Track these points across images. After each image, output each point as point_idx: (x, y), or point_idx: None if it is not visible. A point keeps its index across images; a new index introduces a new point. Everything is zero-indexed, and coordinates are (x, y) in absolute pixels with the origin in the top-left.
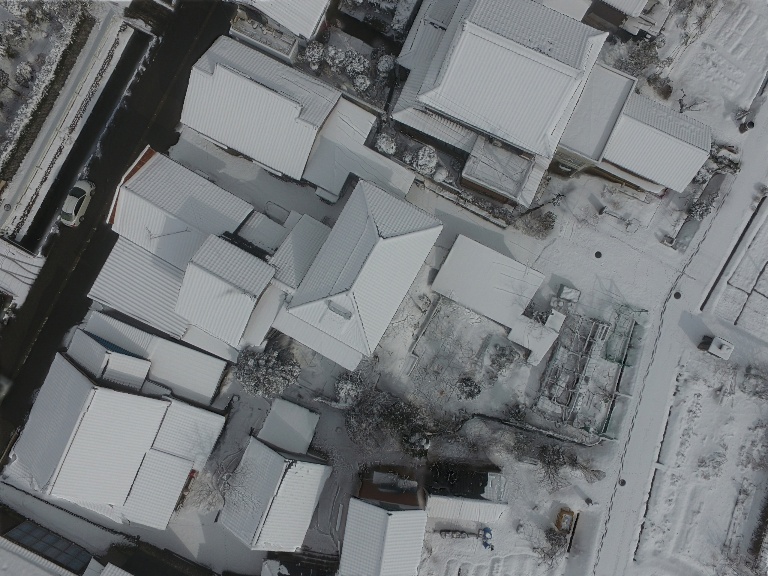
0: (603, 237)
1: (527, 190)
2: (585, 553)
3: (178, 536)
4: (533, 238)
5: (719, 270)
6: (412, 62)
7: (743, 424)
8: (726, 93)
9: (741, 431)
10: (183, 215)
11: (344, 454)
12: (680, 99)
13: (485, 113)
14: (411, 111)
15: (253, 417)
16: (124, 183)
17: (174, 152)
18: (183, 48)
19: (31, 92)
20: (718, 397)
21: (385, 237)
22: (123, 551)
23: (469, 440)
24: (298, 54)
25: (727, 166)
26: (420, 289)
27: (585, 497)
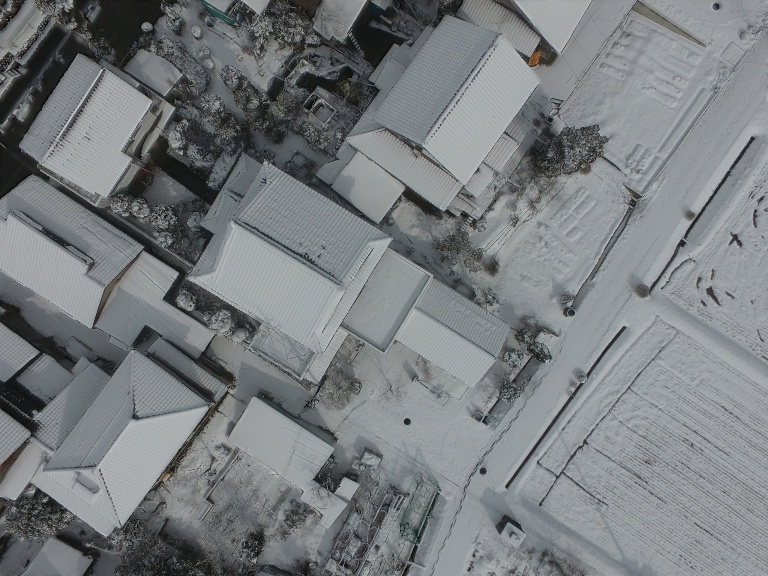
0: (414, 404)
1: (317, 367)
2: None
3: None
4: (330, 407)
5: (528, 450)
6: (215, 227)
7: None
8: (555, 275)
9: None
10: None
11: None
12: None
13: (258, 303)
14: None
15: (31, 550)
16: None
17: None
18: (8, 171)
19: None
20: None
21: (140, 417)
22: None
23: None
24: (111, 199)
25: (535, 357)
26: (217, 439)
27: None
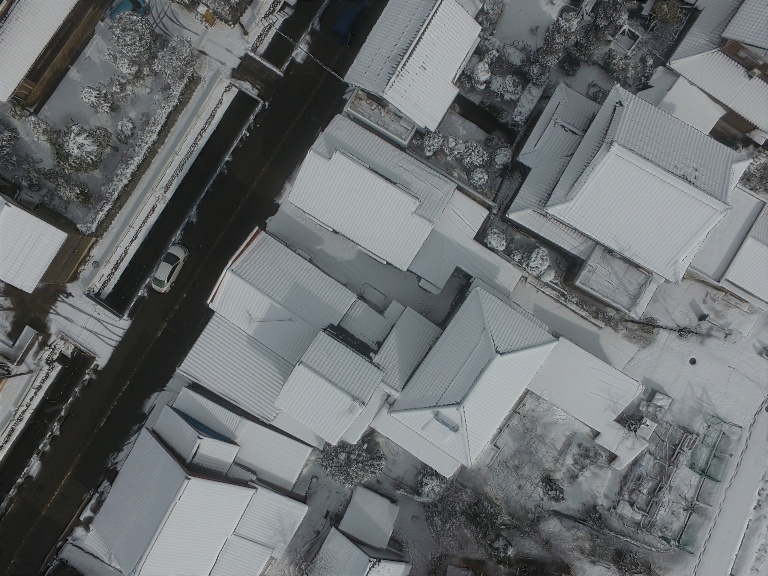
0: (699, 343)
1: (639, 302)
2: None
3: None
4: None
5: None
6: (534, 161)
7: None
8: None
9: None
10: (288, 303)
11: (418, 544)
12: None
13: (616, 232)
14: (529, 212)
15: (330, 500)
16: (230, 266)
17: (272, 223)
18: (290, 116)
19: (133, 152)
20: None
21: (501, 352)
22: None
23: (542, 536)
24: (413, 138)
25: None
26: None
27: None
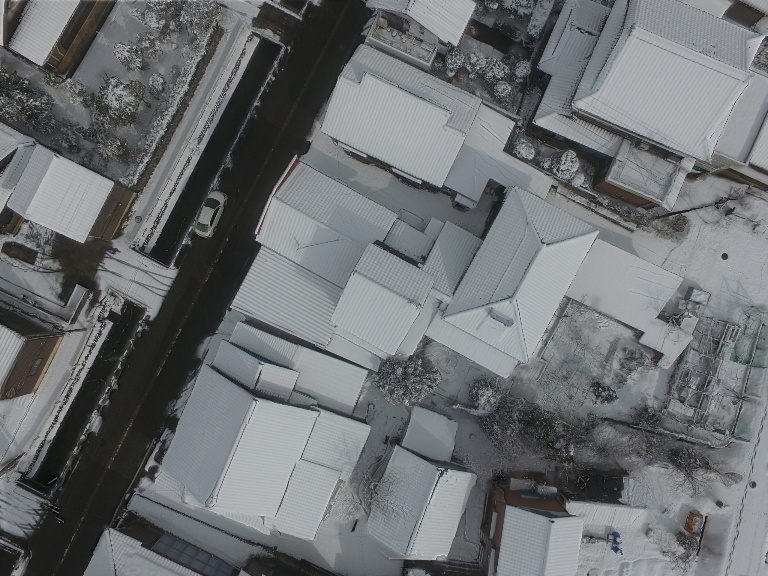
0: (729, 239)
1: (670, 193)
2: (716, 556)
3: (315, 546)
4: (668, 241)
5: None
6: (554, 67)
7: None
8: None
9: None
10: (334, 225)
11: (479, 461)
12: None
13: (643, 117)
14: (555, 116)
15: (388, 425)
16: (275, 194)
17: (305, 161)
18: (312, 57)
19: (167, 104)
20: None
21: (547, 243)
22: (263, 562)
23: (598, 444)
24: (434, 61)
25: None
26: None
27: (715, 500)
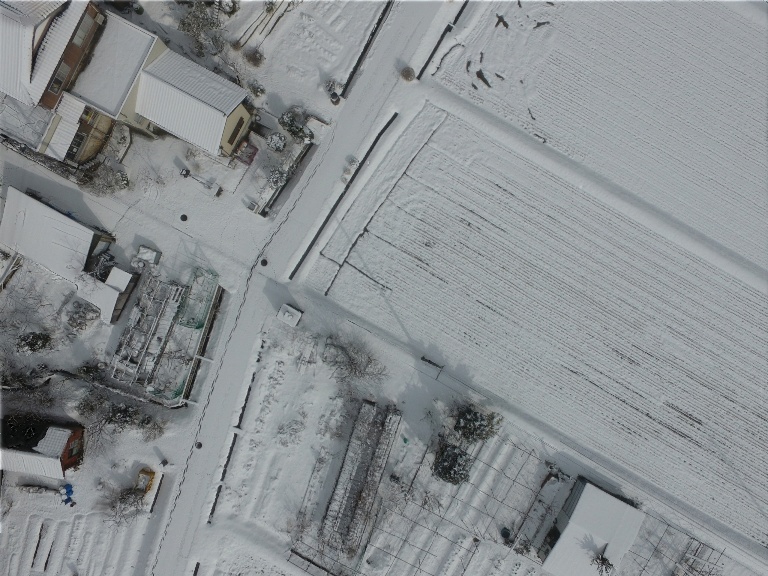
0: (189, 200)
1: (58, 143)
2: (160, 513)
3: None
4: (89, 194)
5: (308, 240)
6: None
7: (324, 393)
8: (322, 64)
9: (322, 400)
10: None
11: None
12: (233, 63)
13: None
14: None
15: None
16: None
17: None
18: None
19: None
20: (297, 365)
21: None
22: None
23: (49, 396)
24: None
25: (292, 134)
26: None
27: (163, 458)
